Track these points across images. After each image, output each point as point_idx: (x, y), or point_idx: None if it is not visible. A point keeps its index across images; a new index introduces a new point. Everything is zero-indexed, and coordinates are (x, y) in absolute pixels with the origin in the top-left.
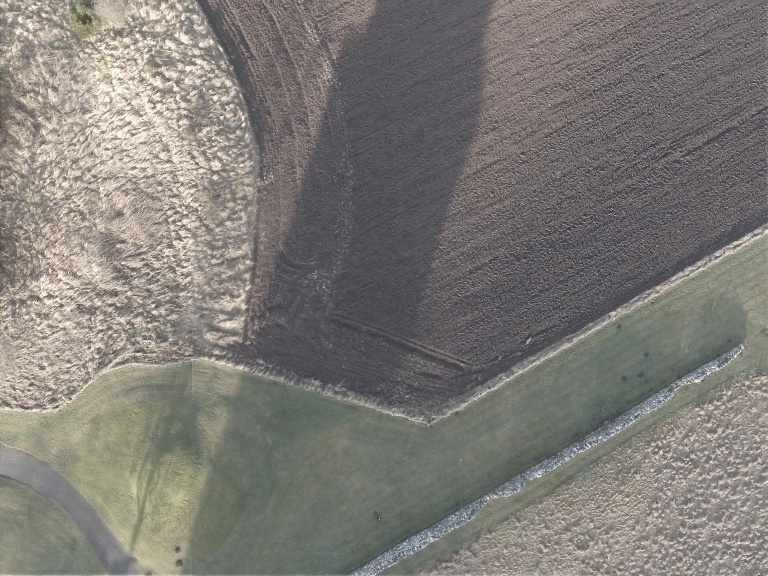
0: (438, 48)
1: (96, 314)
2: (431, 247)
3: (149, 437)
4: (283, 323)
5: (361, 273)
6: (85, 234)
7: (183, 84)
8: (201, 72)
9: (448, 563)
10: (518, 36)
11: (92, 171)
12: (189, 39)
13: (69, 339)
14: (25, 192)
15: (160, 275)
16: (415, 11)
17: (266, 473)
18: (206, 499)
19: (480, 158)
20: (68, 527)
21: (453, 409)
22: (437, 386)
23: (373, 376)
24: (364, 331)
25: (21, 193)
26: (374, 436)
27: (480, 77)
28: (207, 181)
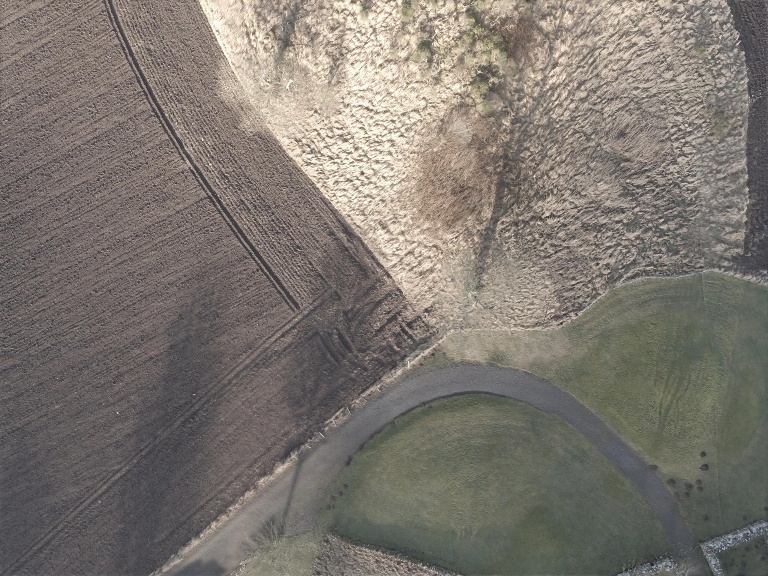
0: None
1: (602, 231)
2: None
3: (672, 346)
4: None
5: None
6: (589, 154)
7: (687, 5)
8: None
9: None
10: None
11: (598, 92)
12: None
13: (573, 257)
14: (534, 114)
15: (665, 191)
16: None
17: None
18: (730, 404)
19: None
20: (575, 440)
21: None
22: None
23: None
24: None
25: (531, 115)
26: None
27: None
28: (715, 97)
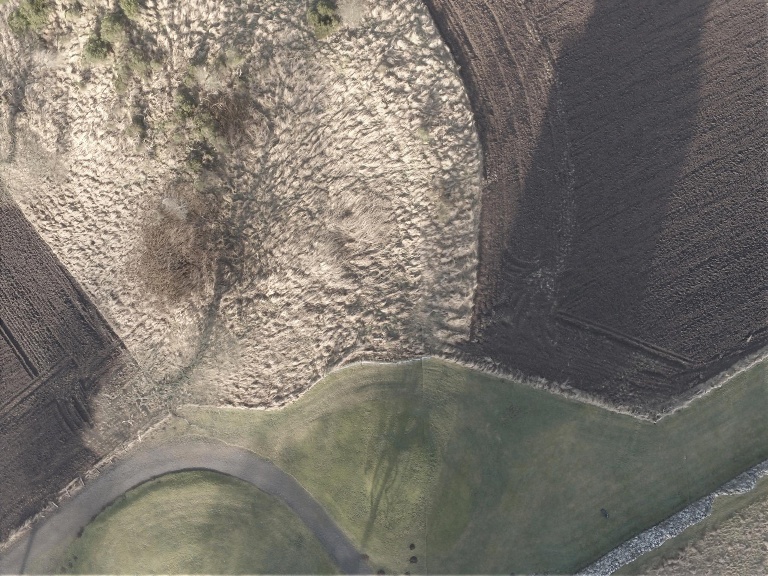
0: (655, 48)
1: (324, 312)
2: (651, 246)
3: (384, 434)
4: (508, 321)
5: (583, 271)
6: (314, 233)
7: (414, 84)
8: (431, 72)
9: (674, 560)
10: (734, 36)
11: (322, 170)
12: (419, 39)
13: (296, 337)
14: (256, 191)
15: (389, 274)
16: (633, 11)
17: (496, 470)
18: (441, 496)
19: (698, 157)
20: (294, 524)
21: (677, 407)
22: (659, 384)
23: (597, 374)
24: (587, 329)
25: (252, 192)
26: (599, 434)
27: (697, 76)
28: (439, 180)
